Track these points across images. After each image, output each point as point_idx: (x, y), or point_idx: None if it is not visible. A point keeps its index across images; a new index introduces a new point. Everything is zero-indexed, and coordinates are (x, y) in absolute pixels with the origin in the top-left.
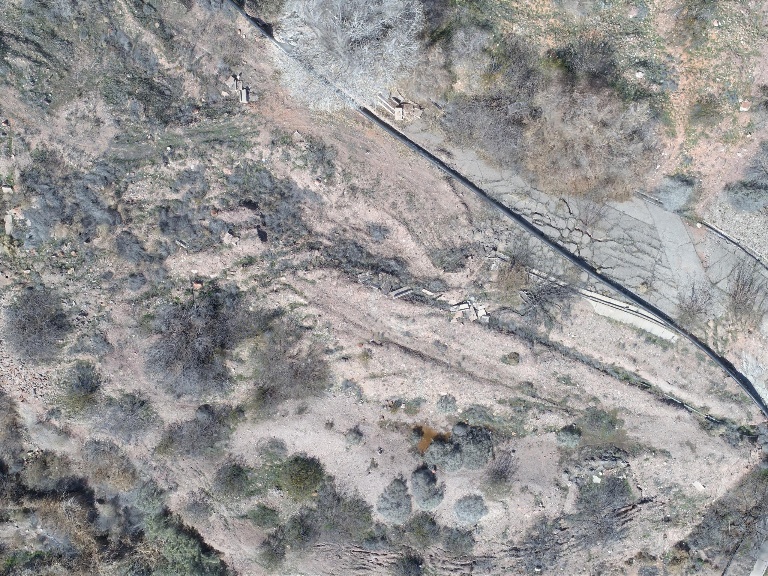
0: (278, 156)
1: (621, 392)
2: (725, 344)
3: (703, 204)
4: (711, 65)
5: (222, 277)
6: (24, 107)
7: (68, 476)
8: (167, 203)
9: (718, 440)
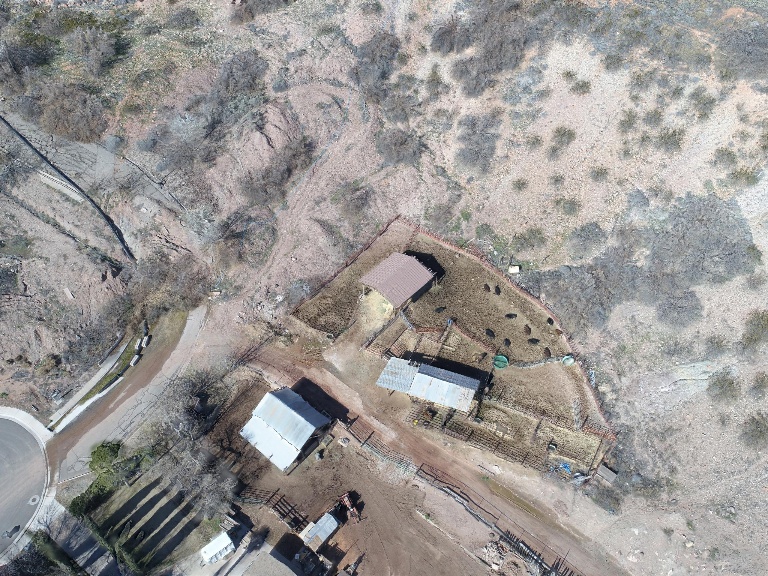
0: None
1: (40, 226)
2: (111, 208)
3: (127, 149)
4: (142, 95)
5: None
6: None
7: None
8: None
9: (84, 256)
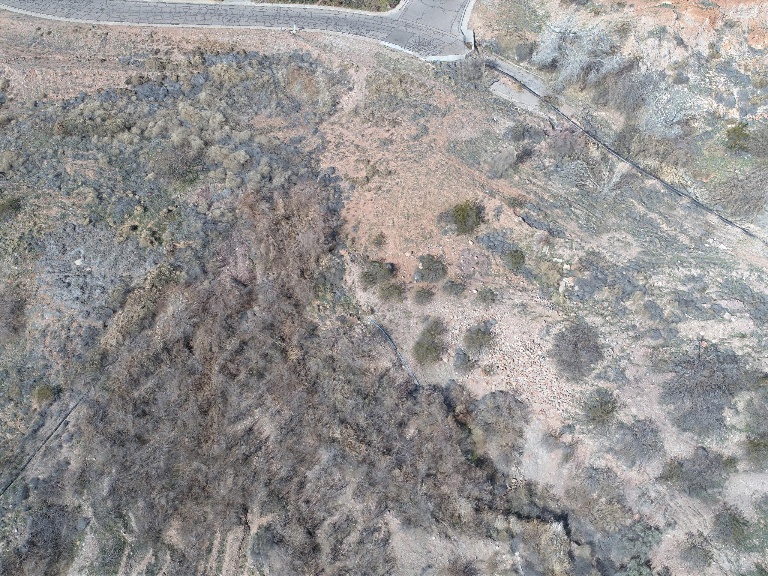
0: (754, 278)
1: None
2: None
3: None
4: None
5: (720, 343)
6: (580, 230)
7: (547, 510)
8: (677, 291)
9: None
